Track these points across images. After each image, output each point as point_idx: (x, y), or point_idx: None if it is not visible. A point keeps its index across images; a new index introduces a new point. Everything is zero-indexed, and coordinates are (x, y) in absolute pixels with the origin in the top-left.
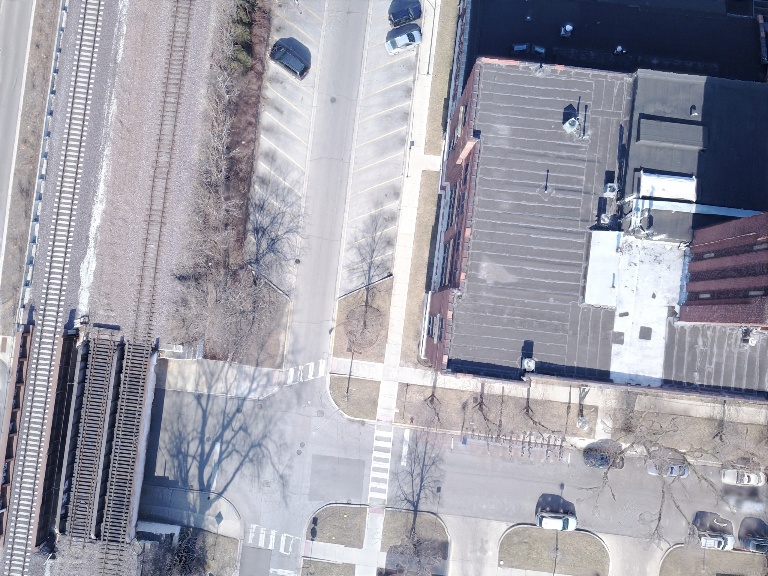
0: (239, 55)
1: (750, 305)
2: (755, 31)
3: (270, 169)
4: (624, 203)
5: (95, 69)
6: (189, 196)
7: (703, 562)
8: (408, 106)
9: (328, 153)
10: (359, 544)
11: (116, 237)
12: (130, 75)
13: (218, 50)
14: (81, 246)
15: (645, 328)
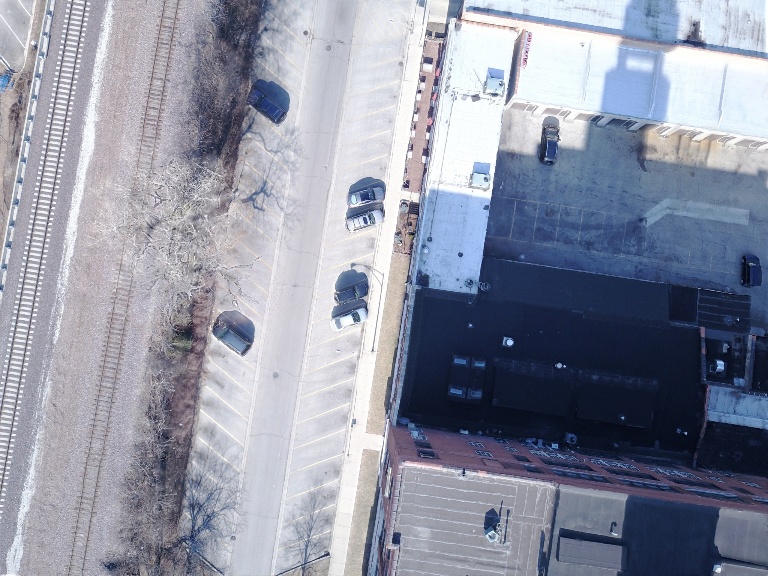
0: None
1: None
2: (696, 344)
3: (209, 444)
4: None
5: (30, 352)
6: (122, 483)
7: None
8: (351, 383)
9: (268, 429)
10: None
11: (45, 524)
12: (66, 356)
13: (158, 332)
14: (8, 534)
15: None
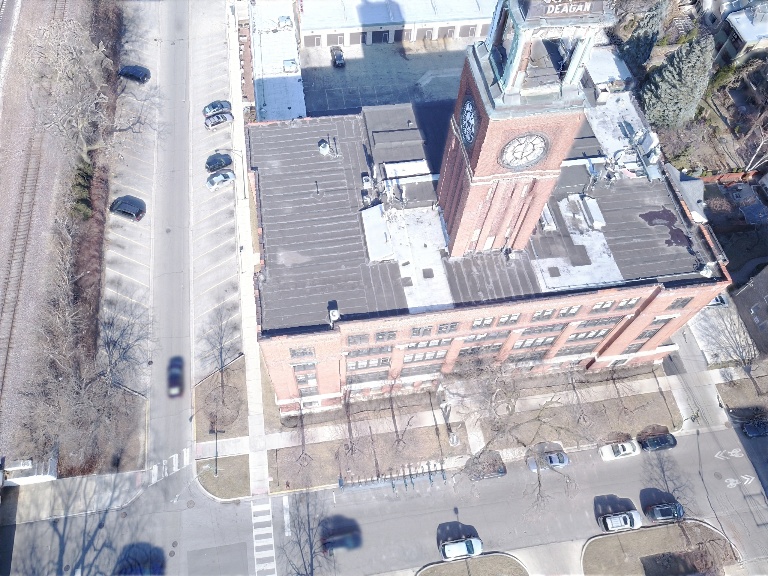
0: (79, 206)
1: (463, 188)
2: None
3: (117, 292)
4: (378, 186)
5: None
6: (37, 321)
7: (622, 549)
8: (233, 223)
9: (169, 269)
10: None
11: None
12: None
13: (62, 209)
14: None
15: (426, 270)
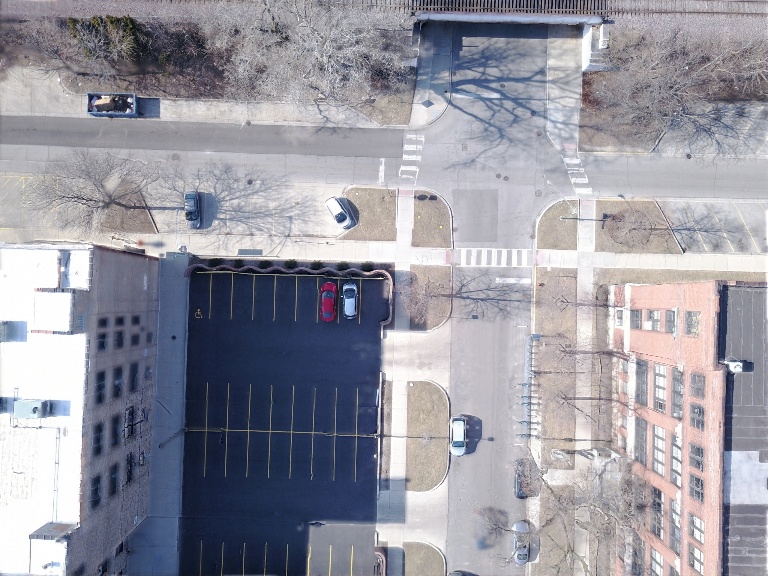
0: None
1: None
2: None
3: None
4: None
5: None
6: (759, 39)
7: None
8: None
9: None
10: (416, 243)
11: None
12: None
13: None
14: None
15: None
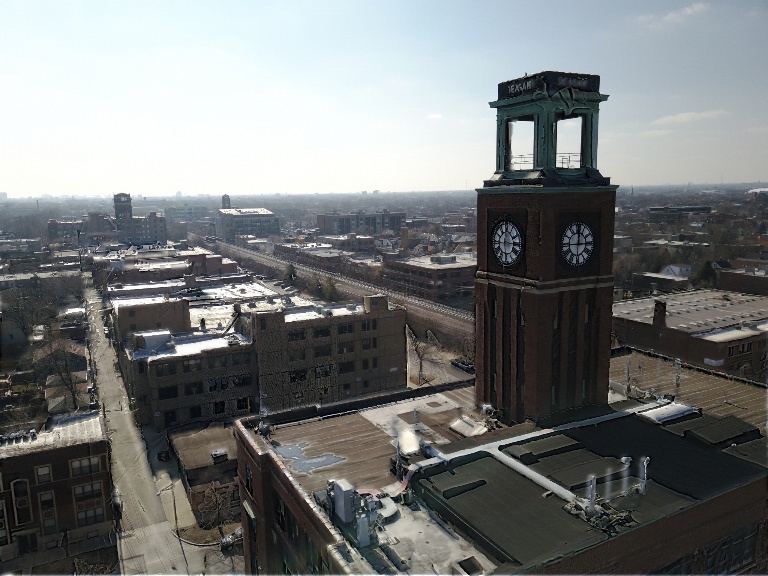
0: None
1: None
2: None
3: None
4: None
5: None
6: None
7: None
8: None
9: None
10: None
11: None
12: None
13: None
14: None
15: None
